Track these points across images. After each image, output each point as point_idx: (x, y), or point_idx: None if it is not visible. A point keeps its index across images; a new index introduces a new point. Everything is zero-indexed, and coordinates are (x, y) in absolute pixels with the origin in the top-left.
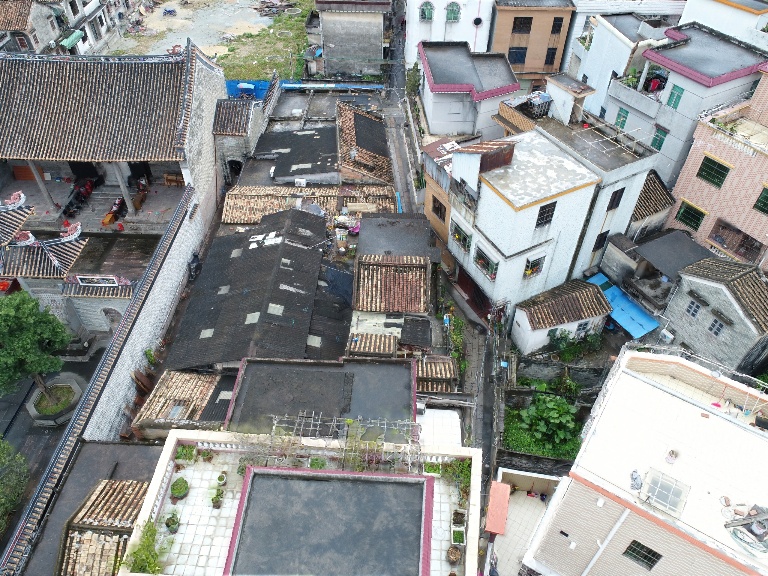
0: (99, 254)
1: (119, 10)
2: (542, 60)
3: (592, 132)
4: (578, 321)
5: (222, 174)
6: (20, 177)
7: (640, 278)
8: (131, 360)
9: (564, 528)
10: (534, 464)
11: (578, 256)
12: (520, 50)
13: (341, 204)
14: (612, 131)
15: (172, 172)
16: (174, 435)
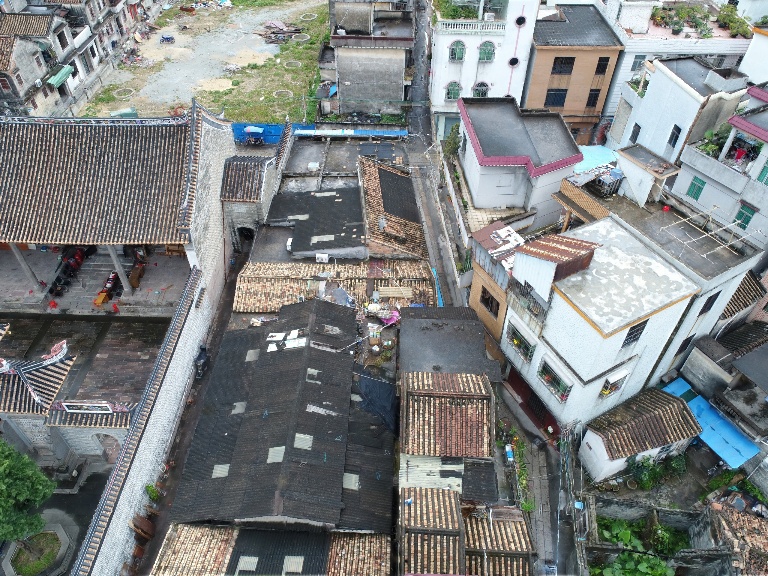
0: (91, 344)
1: (112, 38)
2: (583, 102)
3: (675, 217)
4: (662, 446)
5: (230, 241)
6: (0, 246)
7: (732, 389)
8: (129, 506)
9: None
10: None
11: (659, 364)
12: (559, 92)
13: (371, 288)
14: (700, 218)
15: None
16: None
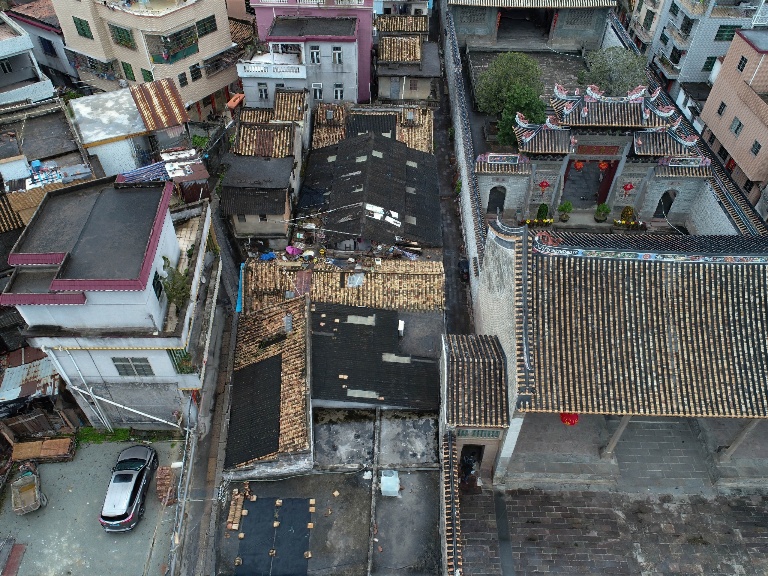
0: None
1: None
2: None
3: None
4: None
5: None
6: None
7: None
8: None
9: None
10: (205, 131)
11: None
12: None
13: None
14: None
15: None
16: None
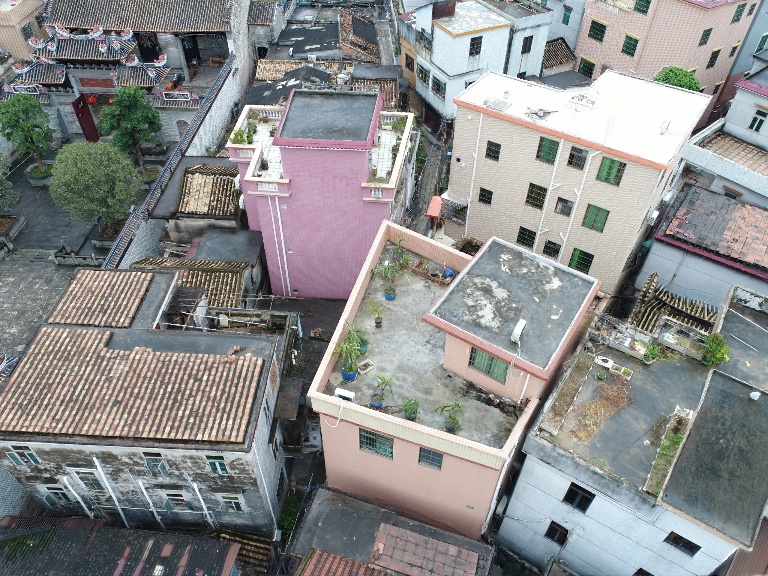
0: None
1: None
2: None
3: None
4: None
5: (253, 59)
6: None
7: None
8: (199, 147)
9: (458, 154)
10: None
11: None
12: None
13: (341, 68)
14: None
15: (216, 55)
16: (248, 106)
